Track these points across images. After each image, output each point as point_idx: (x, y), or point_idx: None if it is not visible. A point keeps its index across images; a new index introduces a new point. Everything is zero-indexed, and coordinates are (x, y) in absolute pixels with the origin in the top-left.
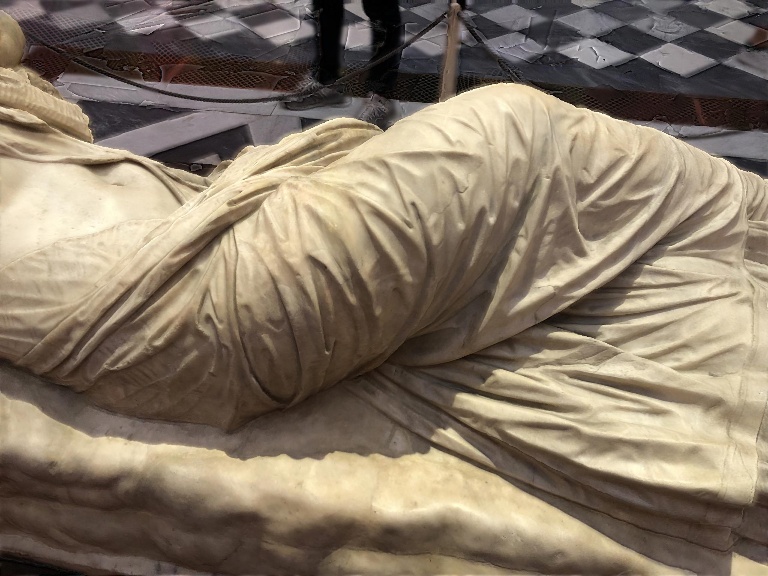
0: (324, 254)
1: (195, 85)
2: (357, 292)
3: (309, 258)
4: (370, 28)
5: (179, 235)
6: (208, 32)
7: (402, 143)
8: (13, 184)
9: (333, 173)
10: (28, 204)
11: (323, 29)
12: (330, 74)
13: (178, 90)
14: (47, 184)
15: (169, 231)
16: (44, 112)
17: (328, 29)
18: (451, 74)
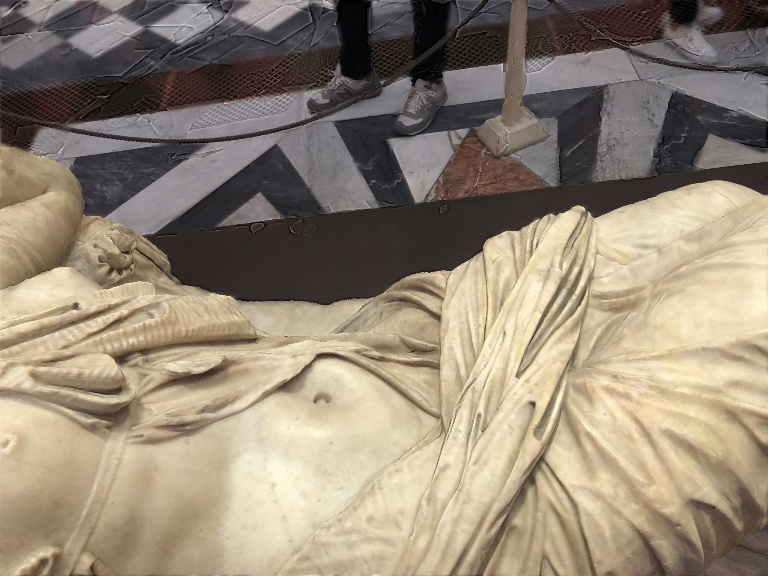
0: (709, 492)
1: (220, 125)
2: (746, 517)
3: (691, 503)
4: (396, 3)
5: (483, 494)
6: (215, 56)
7: (767, 310)
8: (221, 462)
9: (671, 365)
10: (250, 483)
11: (341, 17)
12: (356, 64)
13: (201, 135)
14: (257, 442)
15: (467, 490)
16: (204, 332)
17: (347, 15)
18: (518, 45)
